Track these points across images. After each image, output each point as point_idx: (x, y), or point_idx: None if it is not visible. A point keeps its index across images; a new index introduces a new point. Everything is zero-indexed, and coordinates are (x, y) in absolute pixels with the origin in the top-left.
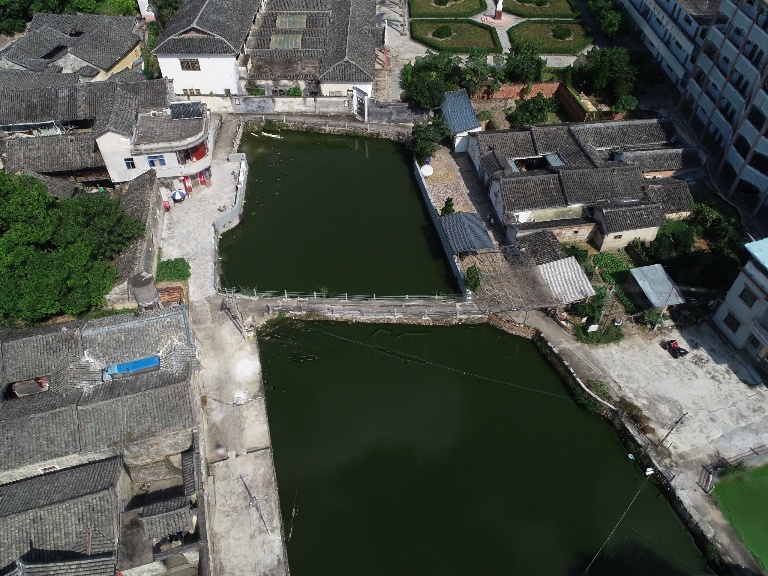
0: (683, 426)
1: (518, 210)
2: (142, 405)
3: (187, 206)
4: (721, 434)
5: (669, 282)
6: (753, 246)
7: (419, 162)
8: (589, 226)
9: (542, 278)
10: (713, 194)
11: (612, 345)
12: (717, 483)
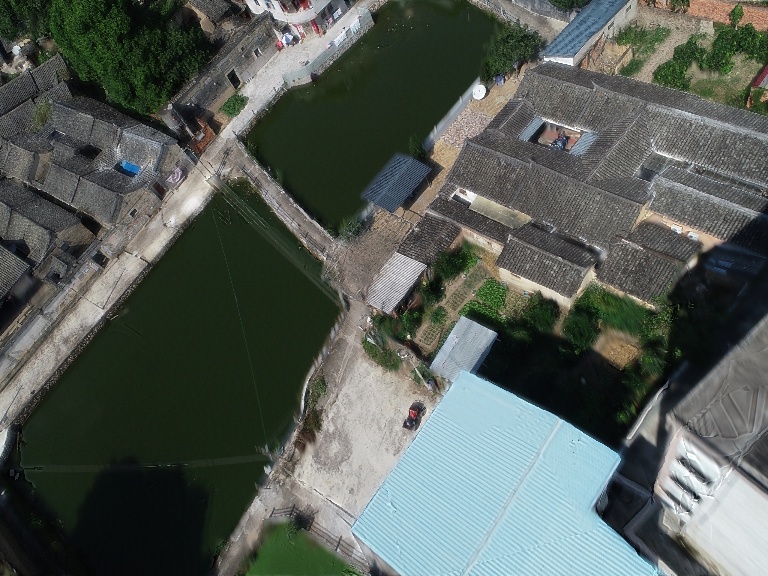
0: (326, 471)
1: (457, 185)
2: (99, 195)
3: (293, 51)
4: (339, 505)
5: (478, 357)
6: (465, 378)
7: (480, 79)
8: (501, 245)
9: (378, 267)
10: (726, 305)
11: (379, 369)
12: (271, 521)
